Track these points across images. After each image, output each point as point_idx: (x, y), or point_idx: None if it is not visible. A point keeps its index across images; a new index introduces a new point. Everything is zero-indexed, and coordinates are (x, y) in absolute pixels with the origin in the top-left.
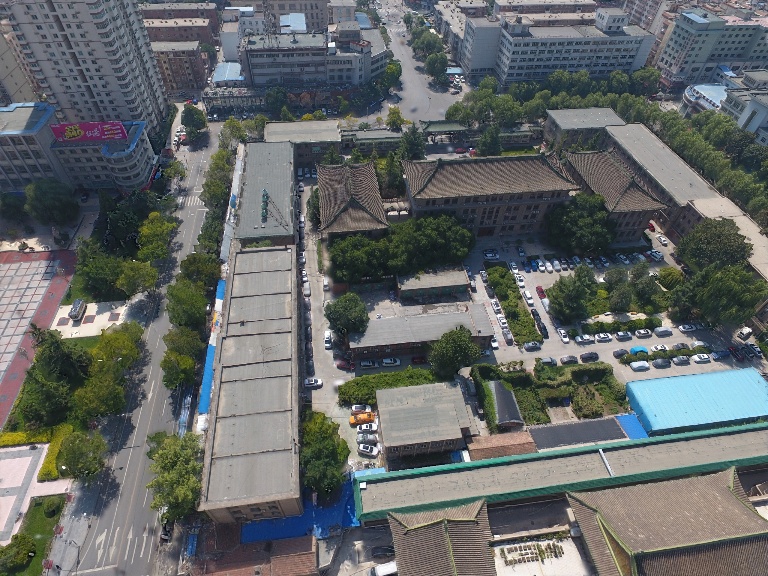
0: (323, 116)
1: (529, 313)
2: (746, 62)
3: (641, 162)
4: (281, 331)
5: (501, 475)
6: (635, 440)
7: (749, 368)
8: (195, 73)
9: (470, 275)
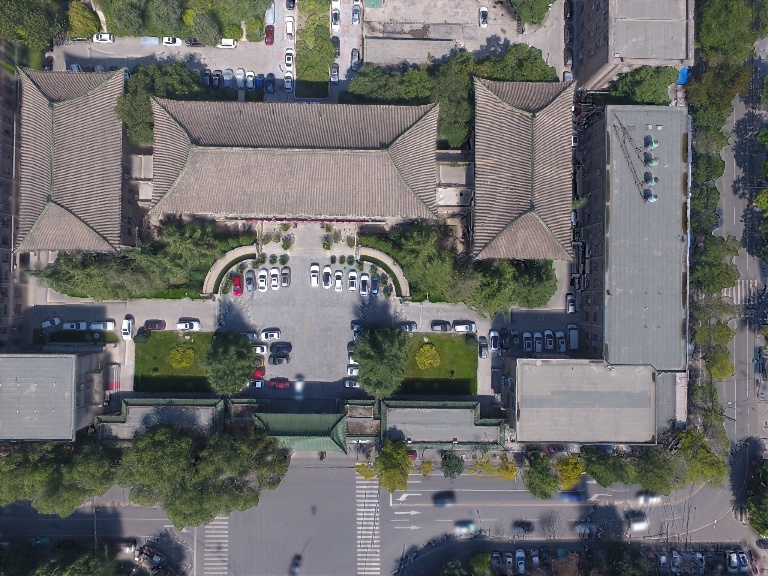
0: (541, 472)
1: (299, 3)
2: None
3: None
4: None
5: None
6: None
7: None
8: None
9: None
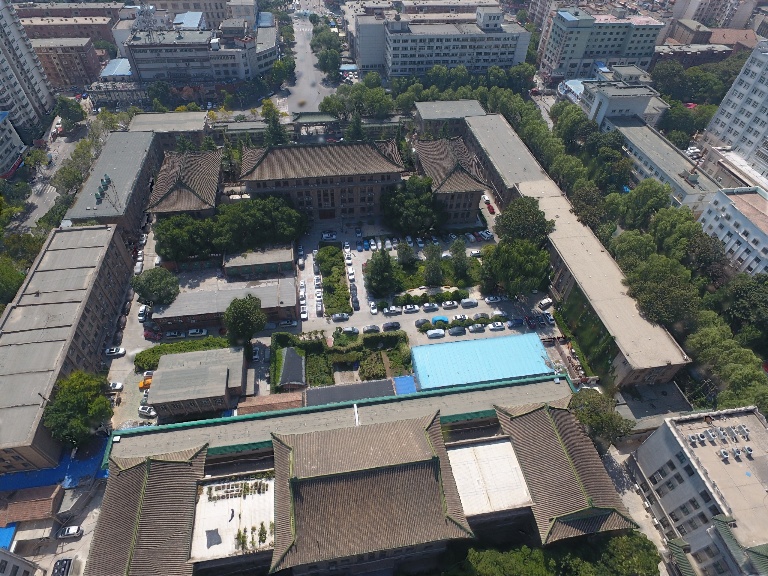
0: (196, 108)
1: (347, 288)
2: (621, 58)
3: (486, 149)
4: (72, 301)
5: (253, 428)
6: (392, 396)
7: (532, 333)
8: (87, 69)
9: (302, 254)
